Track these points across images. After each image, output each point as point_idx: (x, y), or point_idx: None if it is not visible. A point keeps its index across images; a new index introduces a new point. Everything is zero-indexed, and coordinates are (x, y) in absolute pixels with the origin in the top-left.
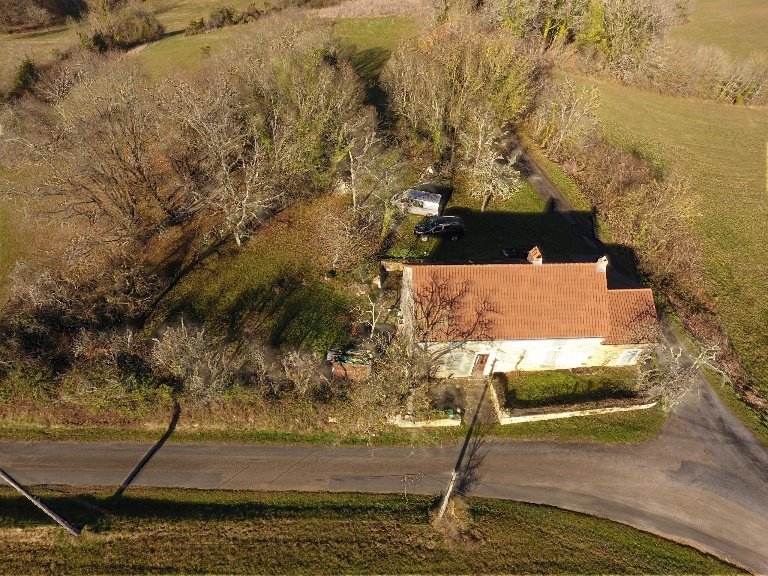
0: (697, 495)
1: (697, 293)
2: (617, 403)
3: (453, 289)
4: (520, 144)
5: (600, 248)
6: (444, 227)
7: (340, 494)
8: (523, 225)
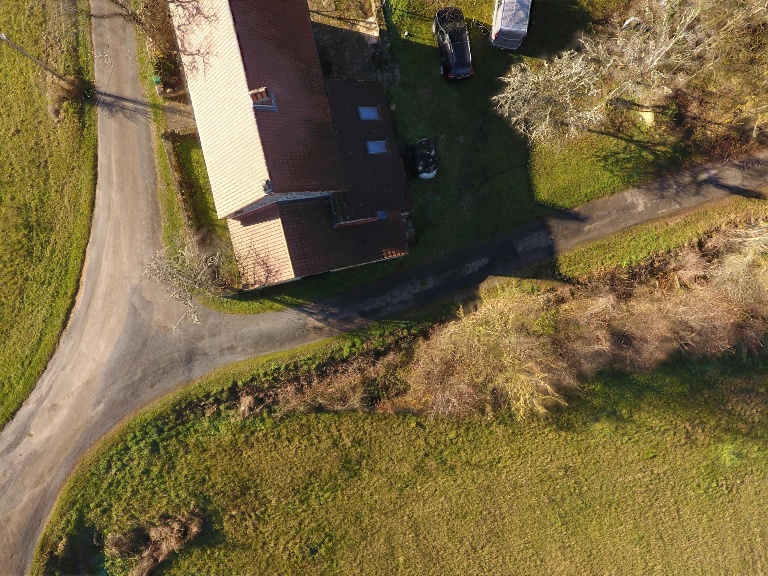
0: (122, 306)
1: (410, 397)
2: (195, 247)
3: (208, 6)
4: (765, 185)
5: (464, 278)
6: (446, 43)
7: (87, 1)
8: (495, 170)
